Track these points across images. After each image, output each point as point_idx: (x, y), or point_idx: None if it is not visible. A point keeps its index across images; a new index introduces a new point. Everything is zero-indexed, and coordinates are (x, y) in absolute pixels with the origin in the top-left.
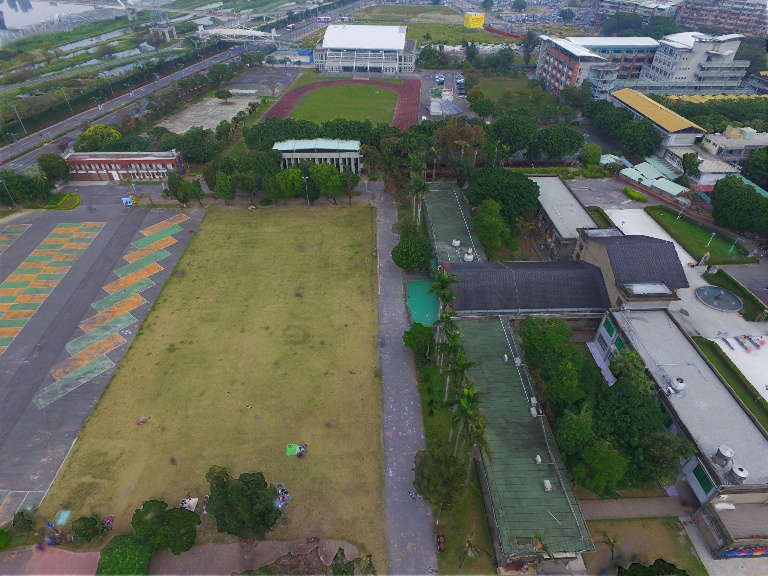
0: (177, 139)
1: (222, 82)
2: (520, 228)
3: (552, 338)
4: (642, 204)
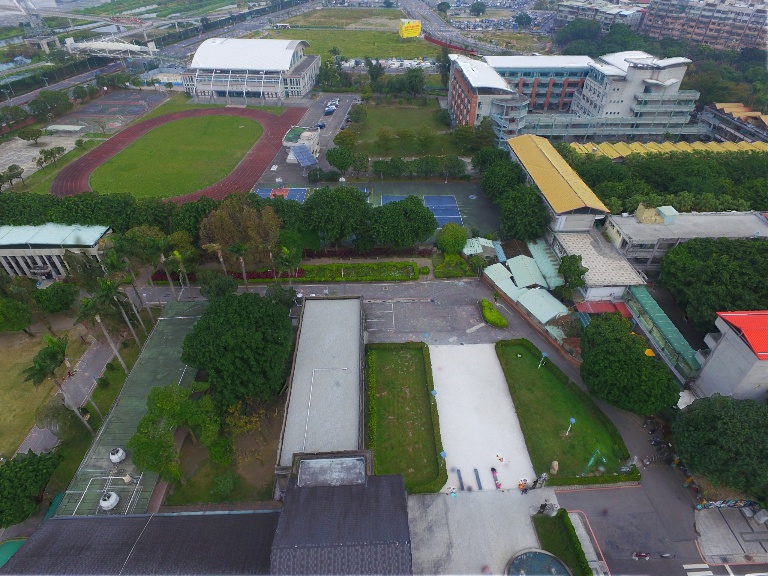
0: None
1: (49, 114)
2: (231, 427)
3: None
4: (497, 333)
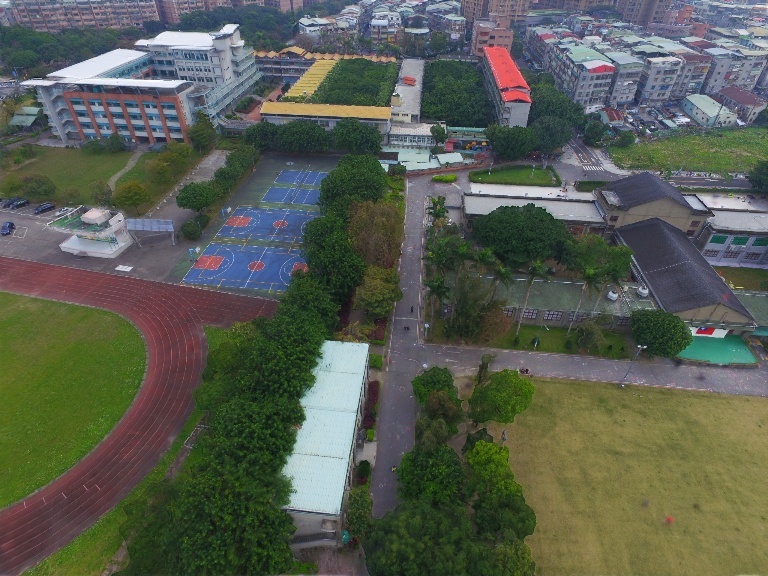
0: None
1: None
2: None
3: None
4: (461, 181)
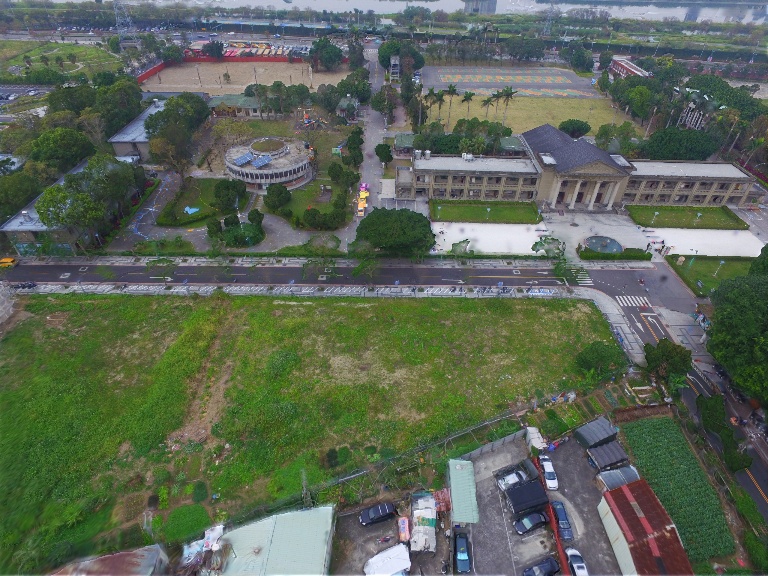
0: (663, 69)
1: None
2: None
3: (484, 121)
4: None
